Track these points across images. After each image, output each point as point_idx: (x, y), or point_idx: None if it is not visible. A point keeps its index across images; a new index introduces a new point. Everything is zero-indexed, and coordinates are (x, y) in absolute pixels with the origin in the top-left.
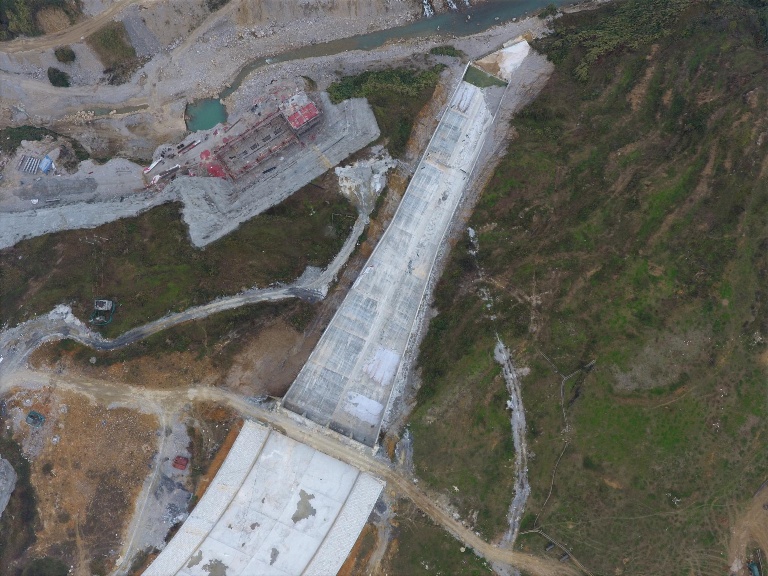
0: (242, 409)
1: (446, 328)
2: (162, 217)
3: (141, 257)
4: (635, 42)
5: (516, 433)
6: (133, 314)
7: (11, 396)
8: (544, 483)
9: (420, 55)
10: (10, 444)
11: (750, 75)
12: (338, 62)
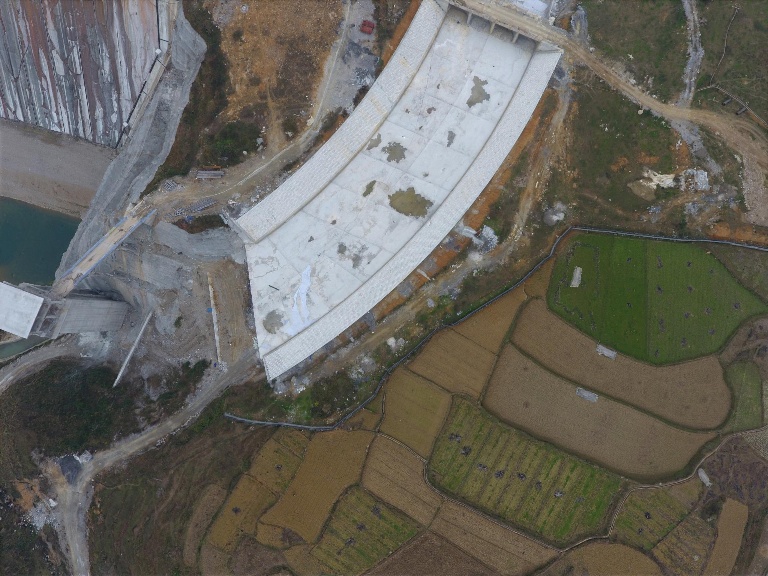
0: None
1: None
2: None
3: None
4: None
5: (687, 3)
6: None
7: None
8: (717, 46)
9: None
10: (201, 12)
11: None
12: None
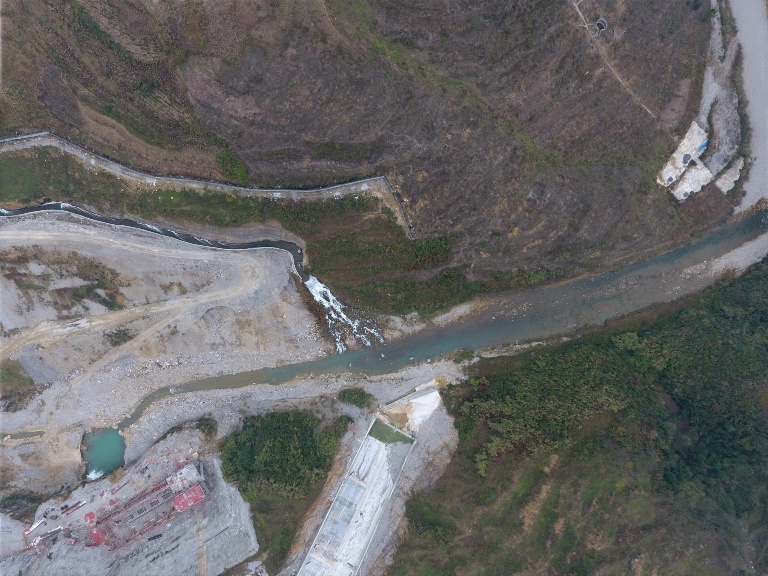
0: None
1: None
2: None
3: None
4: (535, 448)
5: None
6: None
7: None
8: None
9: (327, 400)
10: None
11: (639, 532)
12: (243, 399)
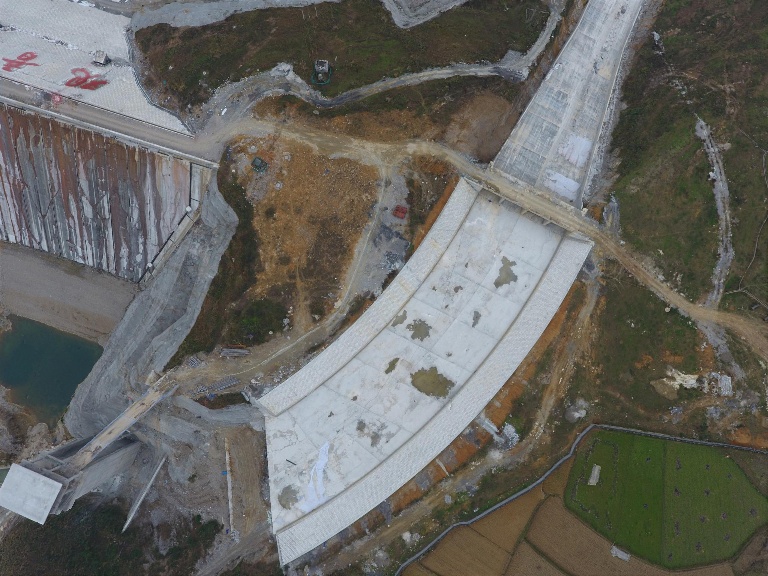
0: (459, 165)
1: (641, 113)
2: (365, 3)
3: (349, 34)
4: None
5: (719, 201)
6: (348, 78)
7: (236, 143)
8: (747, 248)
9: None
10: (235, 187)
11: None
12: None
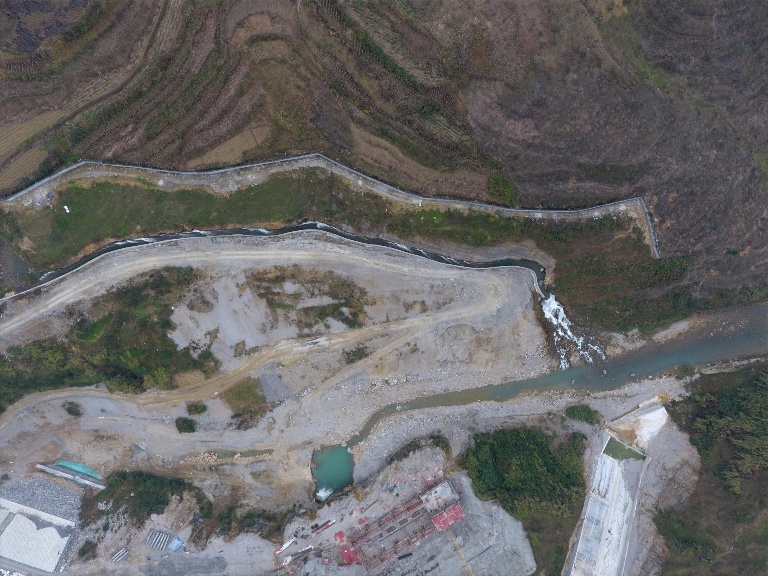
0: None
1: None
2: None
3: None
4: None
5: None
6: None
7: None
8: None
9: (556, 417)
10: None
11: None
12: (471, 416)
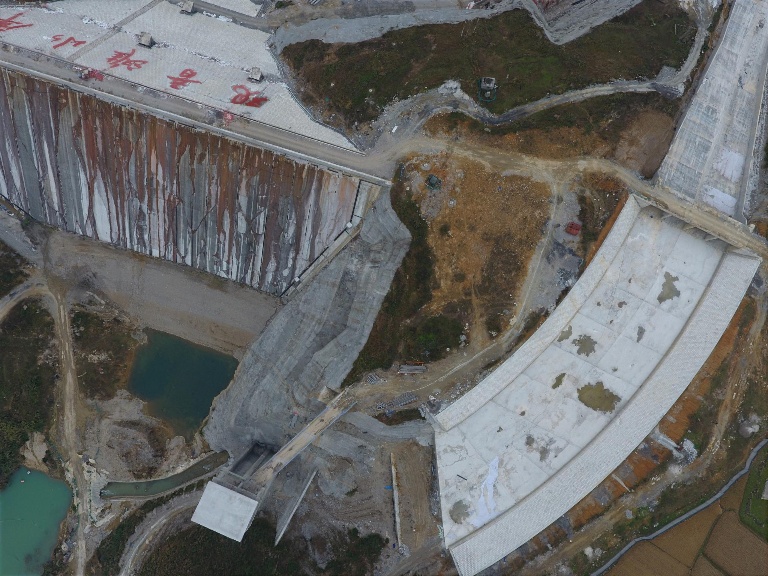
0: (628, 182)
1: None
2: (517, 19)
3: (506, 50)
4: None
5: None
6: (512, 95)
7: (409, 160)
8: None
9: None
10: (409, 205)
11: None
12: None
